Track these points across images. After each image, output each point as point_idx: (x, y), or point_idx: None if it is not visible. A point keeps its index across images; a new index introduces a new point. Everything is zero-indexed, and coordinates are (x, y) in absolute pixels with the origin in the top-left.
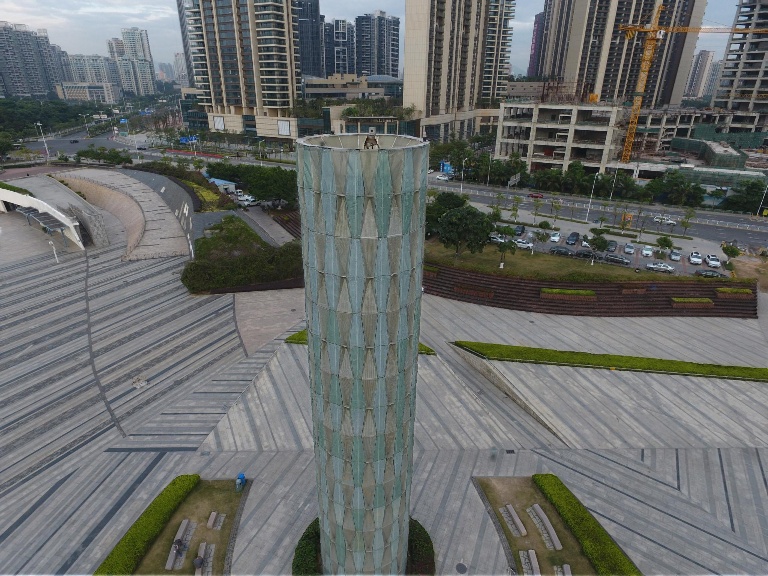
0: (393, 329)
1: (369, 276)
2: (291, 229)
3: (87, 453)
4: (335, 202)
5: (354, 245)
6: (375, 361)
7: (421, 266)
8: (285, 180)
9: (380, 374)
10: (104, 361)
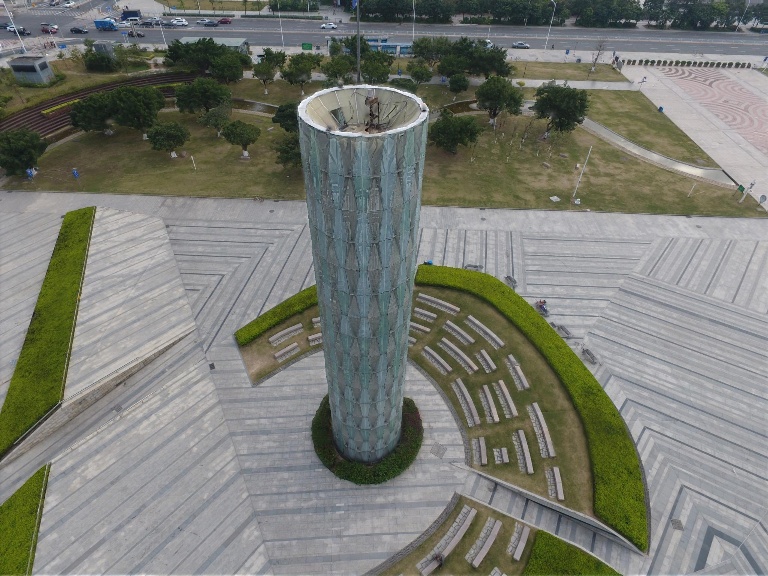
0: None
1: None
2: None
3: None
4: None
5: None
6: None
7: None
8: None
9: None
10: None
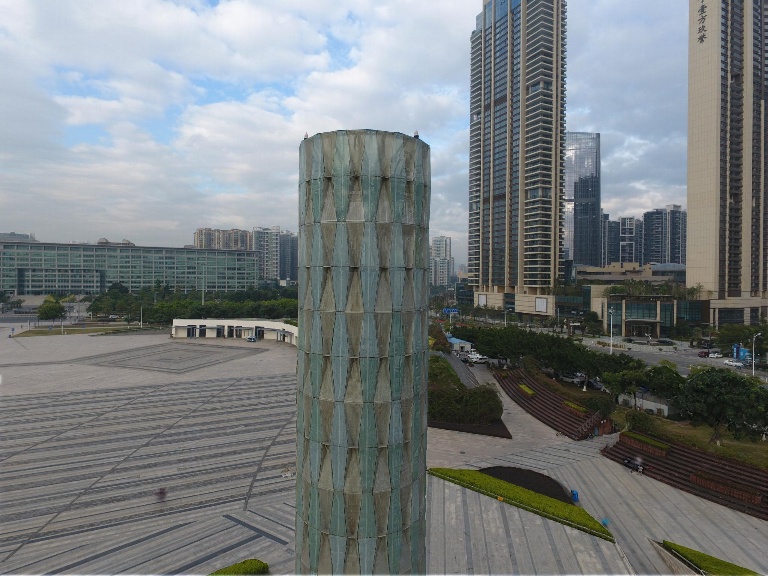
0: (357, 339)
1: (328, 265)
2: (505, 385)
3: (211, 512)
4: (305, 189)
5: (317, 231)
6: (332, 375)
7: (404, 273)
8: (511, 337)
9: (339, 397)
10: (277, 450)
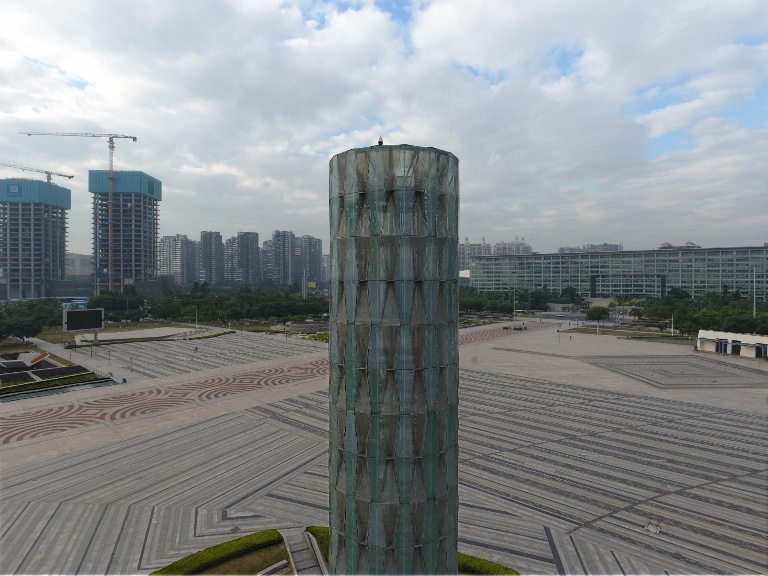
0: None
1: None
2: None
3: (539, 517)
4: None
5: None
6: None
7: (358, 285)
8: None
9: None
10: (674, 500)
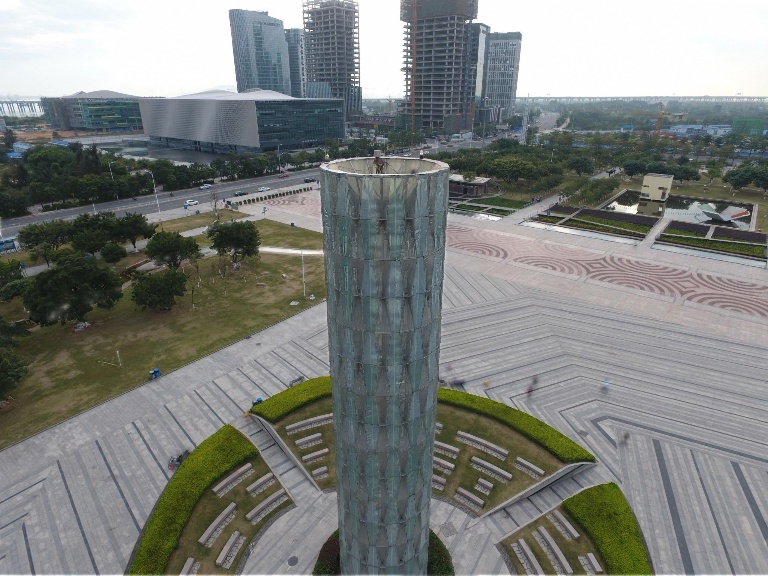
0: None
1: None
2: None
3: None
4: None
5: None
6: None
7: None
8: None
9: None
10: None
